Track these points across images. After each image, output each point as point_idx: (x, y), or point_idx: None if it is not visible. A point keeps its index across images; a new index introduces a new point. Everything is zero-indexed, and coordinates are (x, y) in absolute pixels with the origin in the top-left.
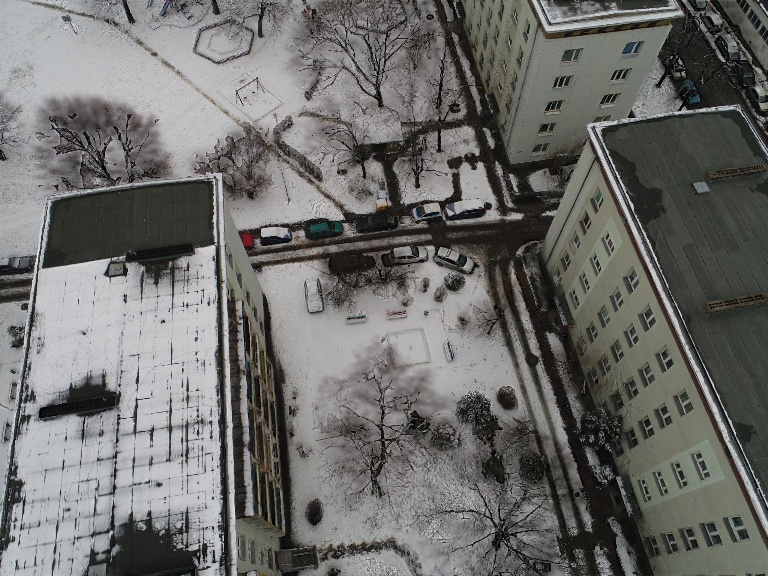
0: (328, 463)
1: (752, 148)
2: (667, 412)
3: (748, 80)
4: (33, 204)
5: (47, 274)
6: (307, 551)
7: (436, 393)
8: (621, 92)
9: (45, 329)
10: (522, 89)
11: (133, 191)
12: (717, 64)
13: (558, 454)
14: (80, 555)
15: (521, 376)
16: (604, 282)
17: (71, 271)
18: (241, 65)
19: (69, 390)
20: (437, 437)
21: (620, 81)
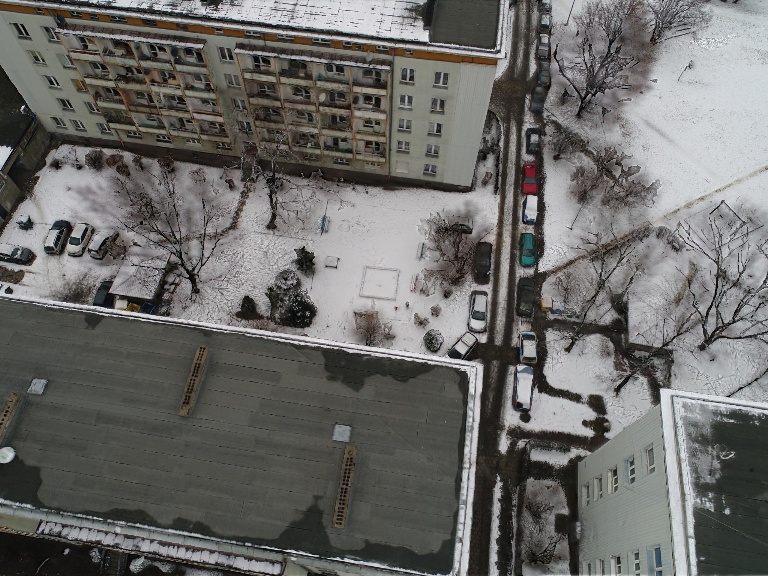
0: None
1: (380, 547)
2: None
3: None
4: None
5: None
6: None
7: (330, 291)
8: None
9: None
10: None
11: (496, 5)
12: None
13: None
14: None
15: None
16: None
17: None
18: None
19: None
20: None
21: (633, 572)
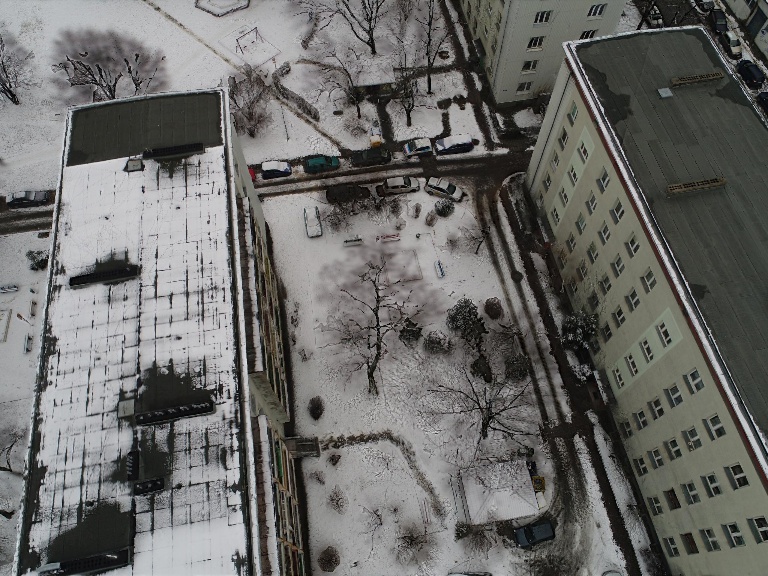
0: (328, 367)
1: (712, 60)
2: (636, 296)
3: (721, 26)
4: (46, 144)
5: (71, 171)
6: (310, 441)
7: (428, 306)
8: (598, 28)
9: (71, 216)
10: (506, 26)
11: (147, 101)
12: (692, 13)
13: (541, 357)
14: (111, 394)
15: (507, 290)
16: (580, 190)
17: (93, 168)
18: (240, 18)
19: (95, 264)
20: (429, 341)
21: (597, 17)
